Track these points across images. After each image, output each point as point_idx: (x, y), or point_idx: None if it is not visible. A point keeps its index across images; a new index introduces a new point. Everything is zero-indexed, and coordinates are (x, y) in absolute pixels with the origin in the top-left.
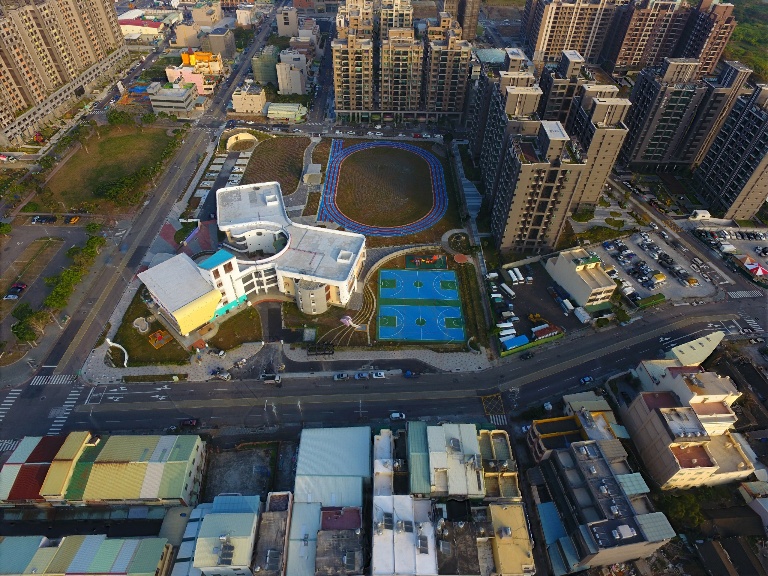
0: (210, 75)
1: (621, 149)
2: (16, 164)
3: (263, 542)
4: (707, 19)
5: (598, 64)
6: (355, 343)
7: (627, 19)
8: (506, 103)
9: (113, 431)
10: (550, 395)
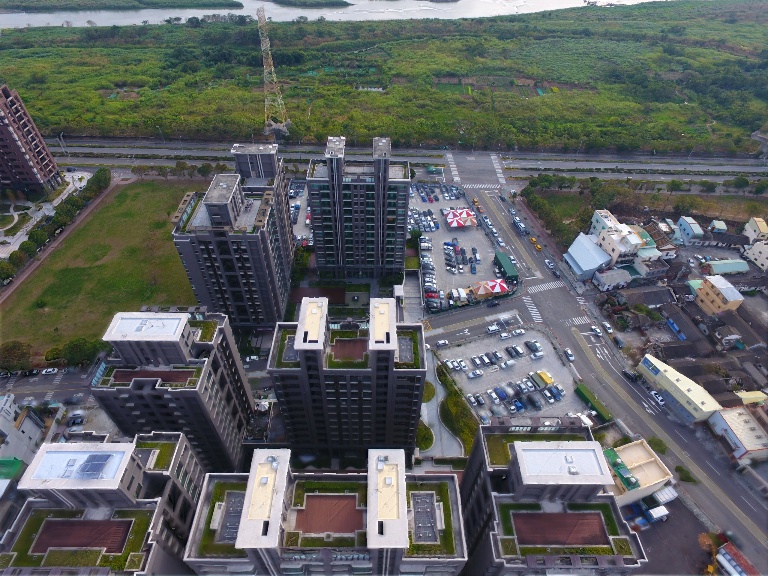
0: None
1: (241, 325)
2: None
3: None
4: None
5: None
6: None
7: None
8: (402, 555)
9: None
10: None
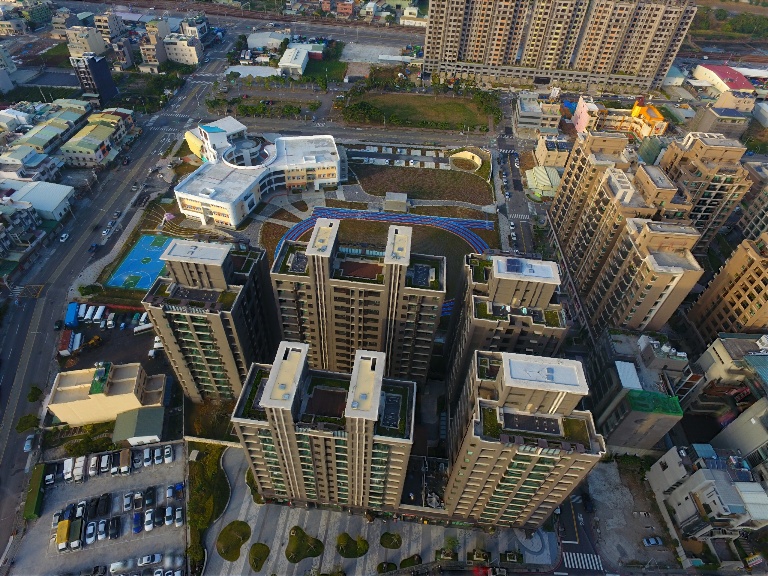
0: (636, 136)
1: None
2: (416, 81)
3: (8, 166)
4: None
5: None
6: (146, 223)
7: None
8: None
9: (140, 142)
10: (8, 332)
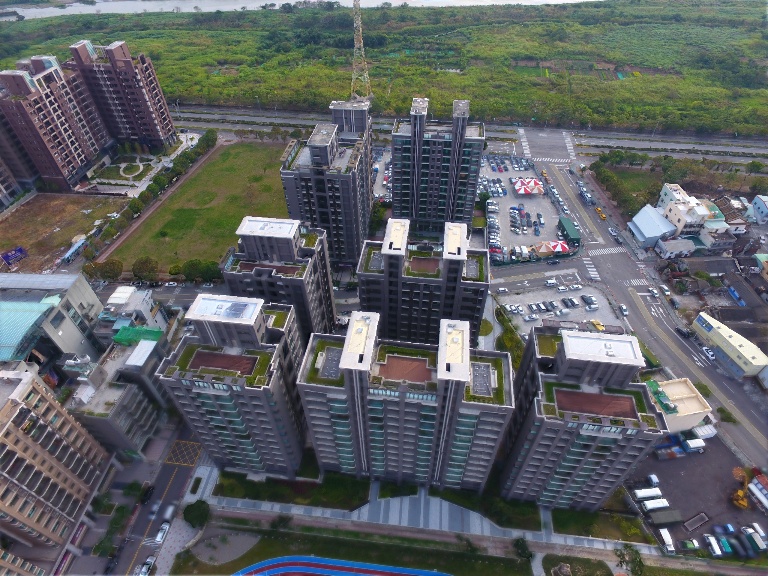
0: None
1: None
2: None
3: None
4: (114, 69)
5: (31, 191)
6: None
7: (17, 118)
8: None
9: None
10: None
